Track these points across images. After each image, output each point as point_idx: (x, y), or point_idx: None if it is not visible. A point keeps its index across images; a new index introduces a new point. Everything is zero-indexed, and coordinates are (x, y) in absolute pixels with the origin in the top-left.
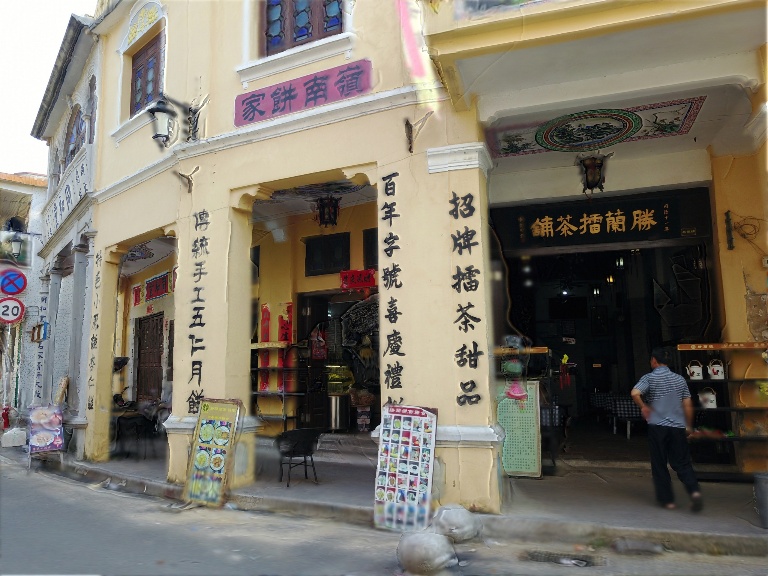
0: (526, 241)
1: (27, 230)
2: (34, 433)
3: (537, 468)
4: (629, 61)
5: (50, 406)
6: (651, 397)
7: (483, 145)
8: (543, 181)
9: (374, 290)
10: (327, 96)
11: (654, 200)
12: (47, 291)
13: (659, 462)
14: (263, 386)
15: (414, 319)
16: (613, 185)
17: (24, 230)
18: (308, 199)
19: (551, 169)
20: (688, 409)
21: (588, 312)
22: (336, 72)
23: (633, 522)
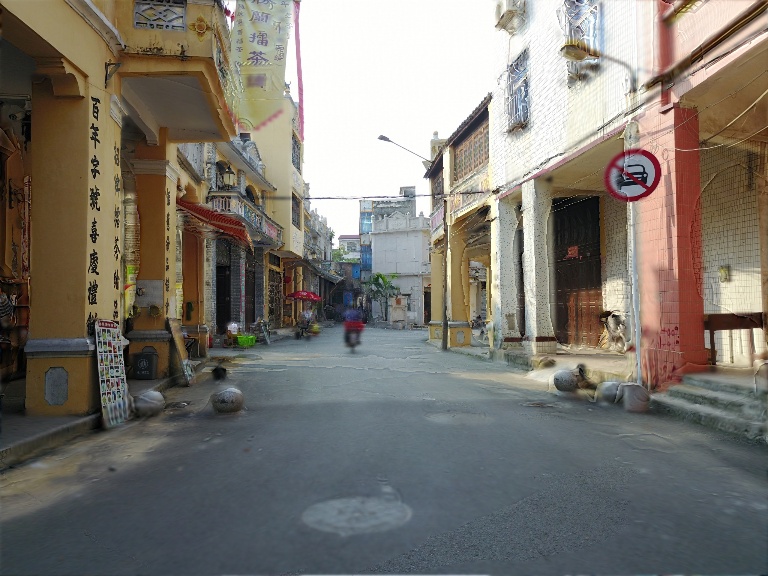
0: None
1: None
2: None
3: None
4: (159, 105)
5: None
6: None
7: None
8: None
9: None
10: None
11: None
12: None
13: None
14: None
15: None
16: None
17: None
18: None
19: None
20: None
21: None
22: None
23: (140, 388)
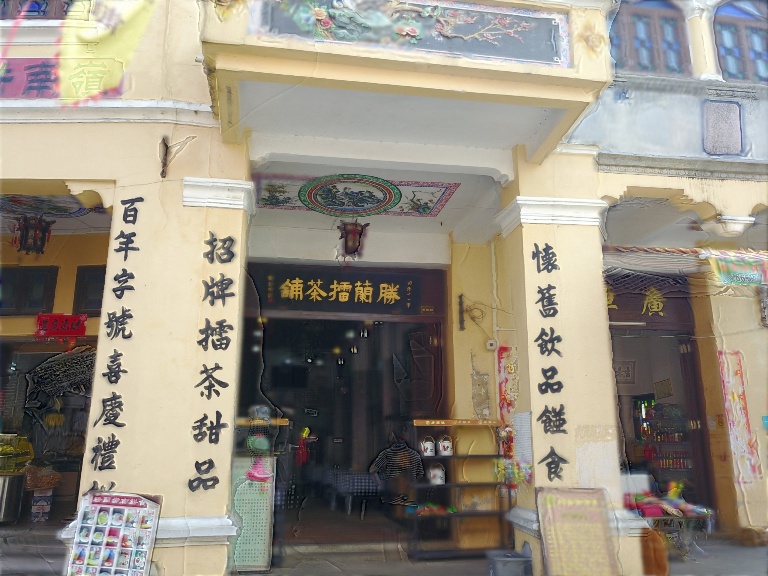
0: (273, 301)
1: None
2: None
3: (267, 560)
4: (406, 132)
5: None
6: (388, 474)
7: (251, 185)
8: (298, 241)
9: (83, 341)
10: (56, 89)
11: (400, 276)
12: None
13: (391, 543)
14: None
15: (143, 379)
16: (365, 255)
17: None
18: (6, 215)
19: (307, 230)
20: (420, 486)
21: (332, 382)
22: (73, 64)
23: None
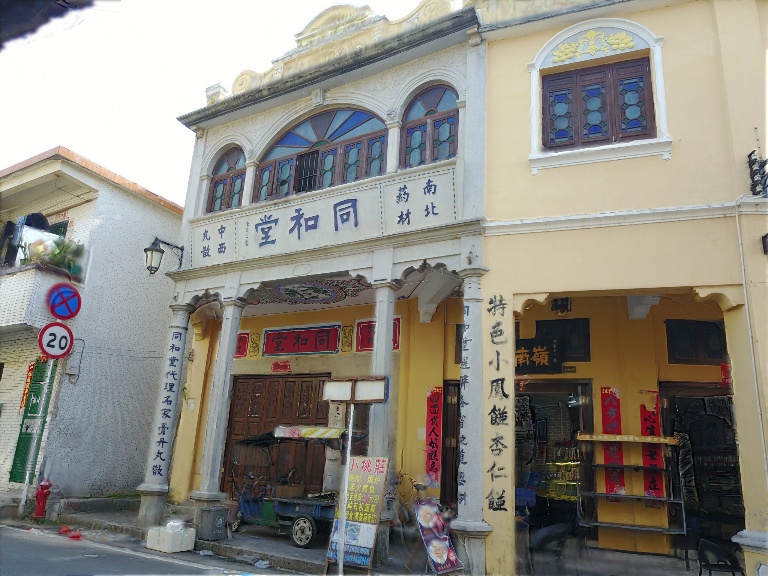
0: None
1: (66, 234)
2: (428, 543)
3: None
4: None
5: (429, 502)
6: None
7: None
8: None
9: None
10: None
11: None
12: (183, 325)
13: None
14: (613, 488)
15: None
16: None
17: (61, 233)
18: None
19: None
20: None
21: None
22: None
23: None
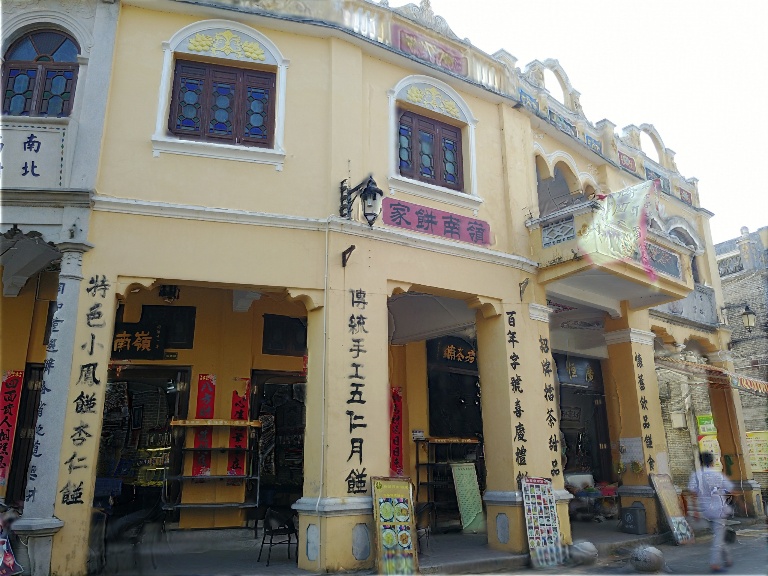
0: (439, 360)
1: None
2: None
3: None
4: (599, 289)
5: None
6: None
7: None
8: None
9: None
10: (460, 235)
11: None
12: None
13: None
14: (199, 470)
15: (531, 416)
16: None
17: None
18: None
19: None
20: None
21: (479, 416)
22: (467, 221)
23: (611, 540)
